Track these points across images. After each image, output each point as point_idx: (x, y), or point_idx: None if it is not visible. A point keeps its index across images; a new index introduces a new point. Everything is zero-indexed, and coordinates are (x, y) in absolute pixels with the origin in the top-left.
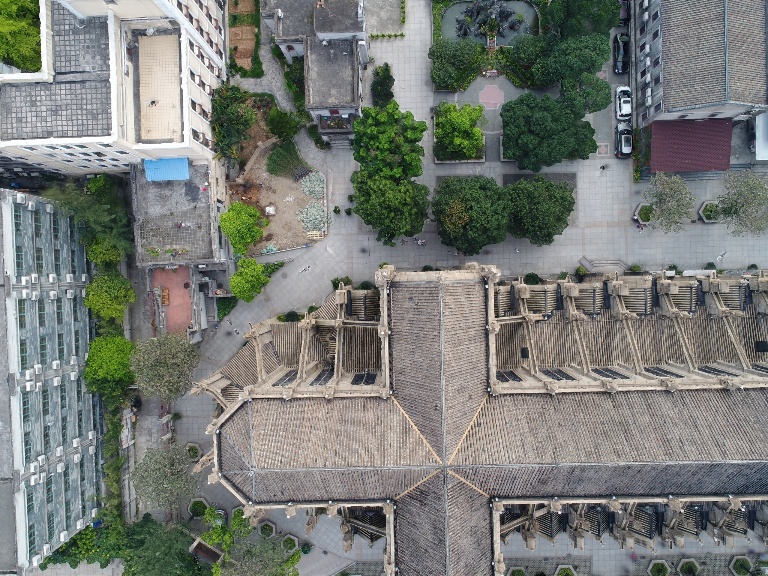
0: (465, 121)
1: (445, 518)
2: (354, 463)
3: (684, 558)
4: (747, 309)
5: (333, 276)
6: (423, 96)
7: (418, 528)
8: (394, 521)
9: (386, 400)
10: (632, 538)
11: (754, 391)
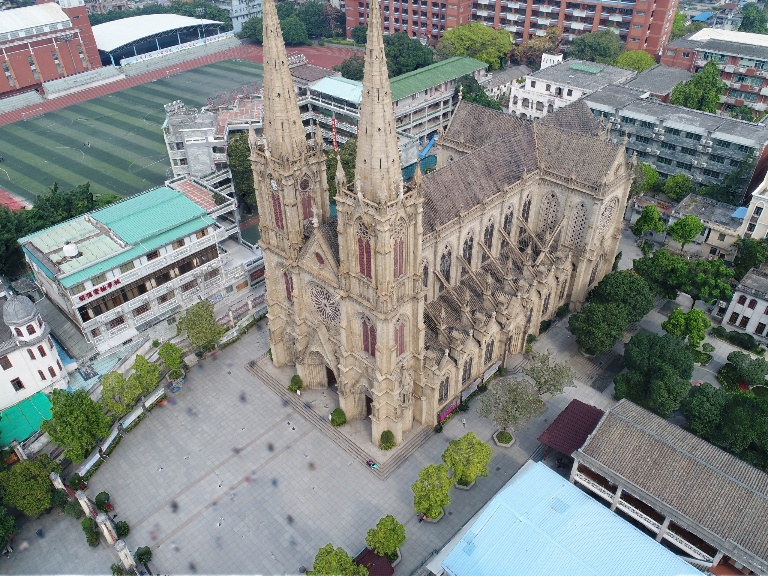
0: (694, 311)
1: None
2: (559, 112)
3: None
4: None
5: (622, 268)
6: (725, 359)
7: None
8: None
9: None
10: None
11: None
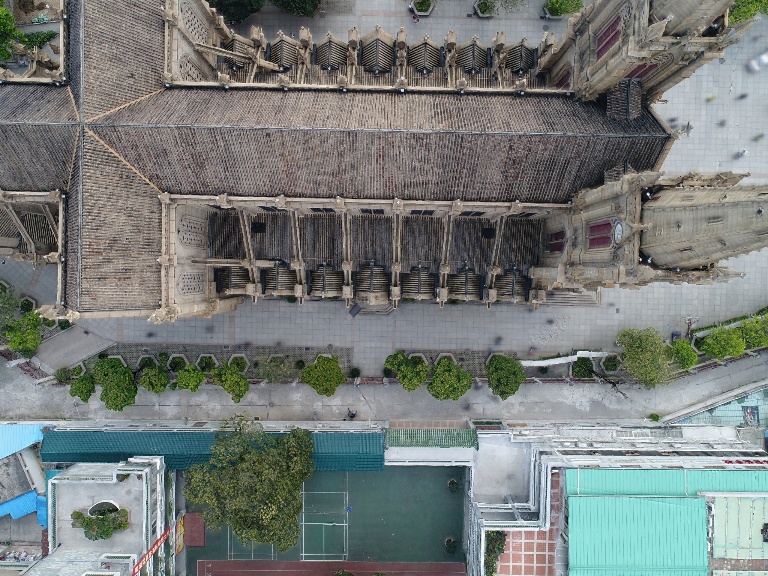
0: None
1: (79, 175)
2: None
3: (442, 352)
4: (483, 72)
5: None
6: None
7: (72, 205)
8: (66, 214)
9: (60, 87)
10: (348, 286)
11: (426, 95)
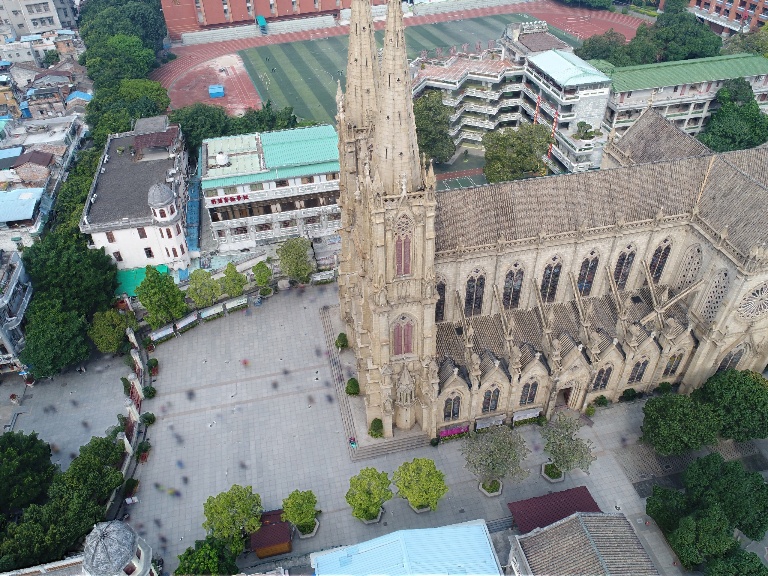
0: None
1: None
2: (767, 151)
3: None
4: None
5: None
6: None
7: None
8: None
9: None
10: None
11: None
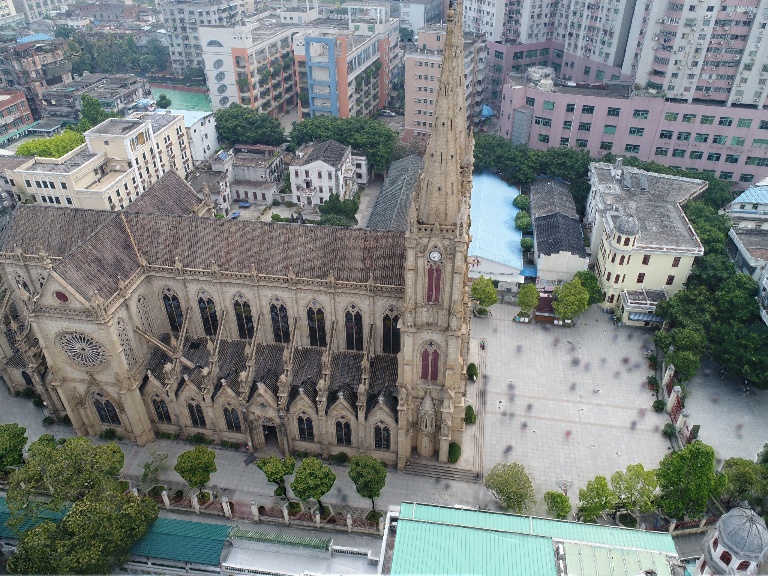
0: None
1: None
2: None
3: (321, 503)
4: None
5: None
6: None
7: None
8: None
9: None
10: (245, 372)
11: None
